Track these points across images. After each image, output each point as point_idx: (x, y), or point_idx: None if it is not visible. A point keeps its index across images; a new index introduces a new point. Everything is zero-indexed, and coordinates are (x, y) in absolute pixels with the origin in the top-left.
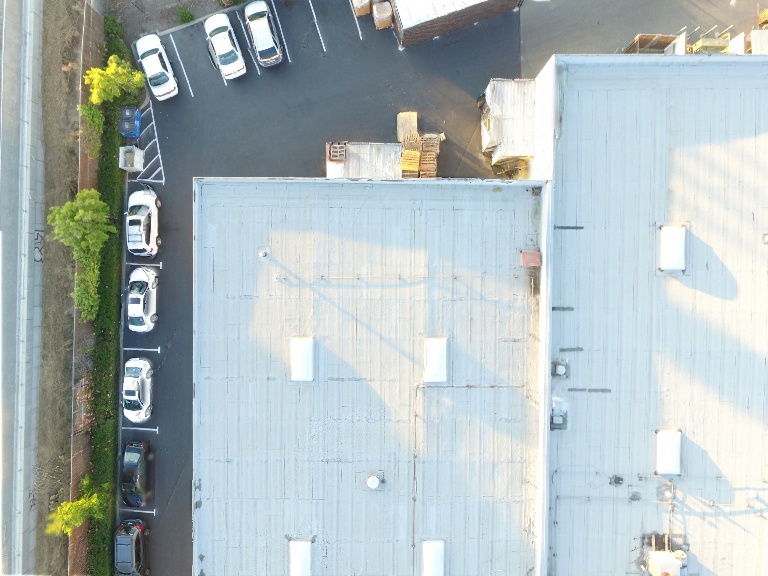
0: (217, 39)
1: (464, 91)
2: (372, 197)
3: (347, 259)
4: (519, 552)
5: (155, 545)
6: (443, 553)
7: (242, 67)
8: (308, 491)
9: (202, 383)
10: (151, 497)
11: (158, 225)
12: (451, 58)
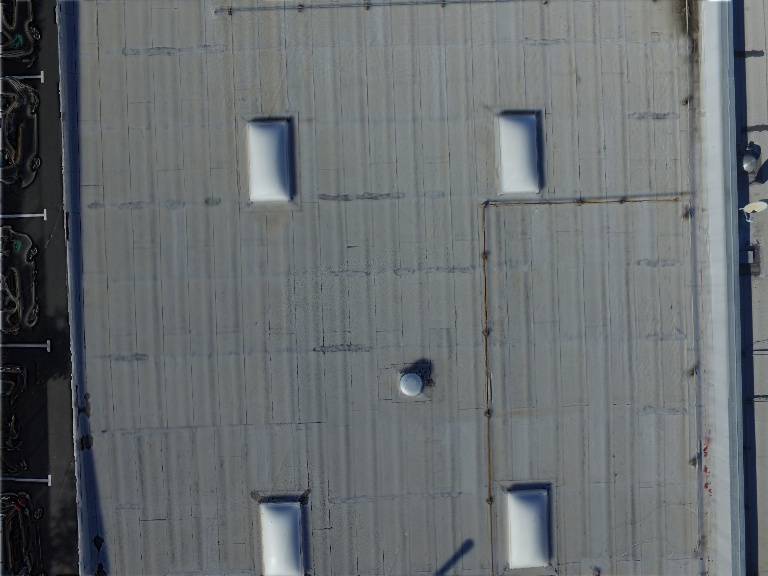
0: None
1: None
2: None
3: None
4: (682, 504)
5: (52, 534)
6: (546, 512)
7: None
8: (290, 408)
9: (84, 214)
10: (43, 456)
11: (32, 5)
12: None
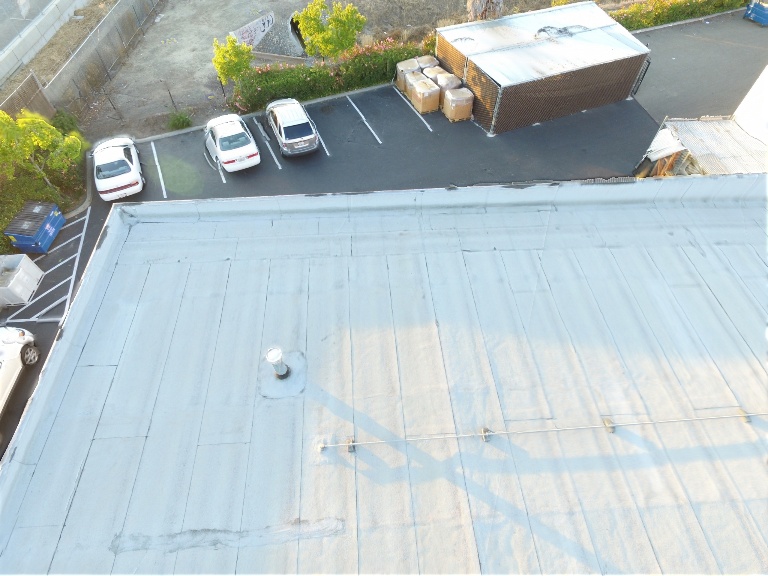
0: (221, 126)
1: (605, 168)
2: (564, 227)
3: (551, 371)
4: None
5: None
6: None
7: (255, 152)
8: None
9: None
10: None
11: (7, 401)
12: (567, 139)
